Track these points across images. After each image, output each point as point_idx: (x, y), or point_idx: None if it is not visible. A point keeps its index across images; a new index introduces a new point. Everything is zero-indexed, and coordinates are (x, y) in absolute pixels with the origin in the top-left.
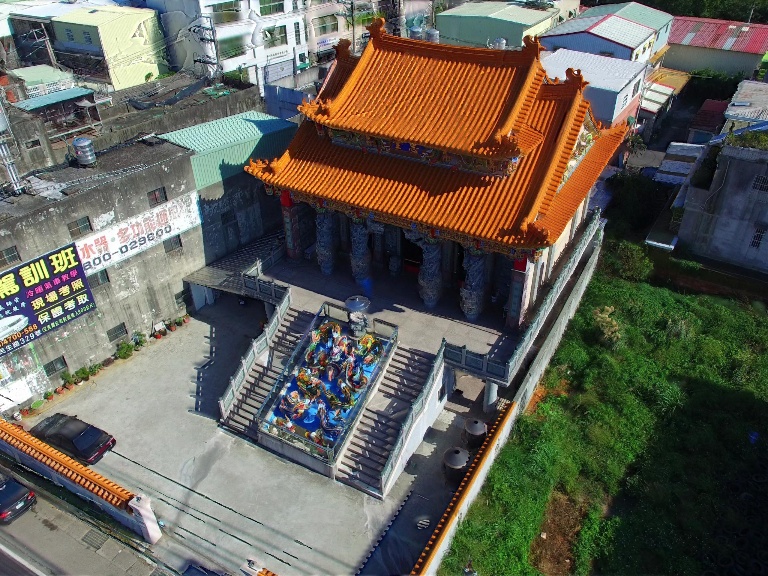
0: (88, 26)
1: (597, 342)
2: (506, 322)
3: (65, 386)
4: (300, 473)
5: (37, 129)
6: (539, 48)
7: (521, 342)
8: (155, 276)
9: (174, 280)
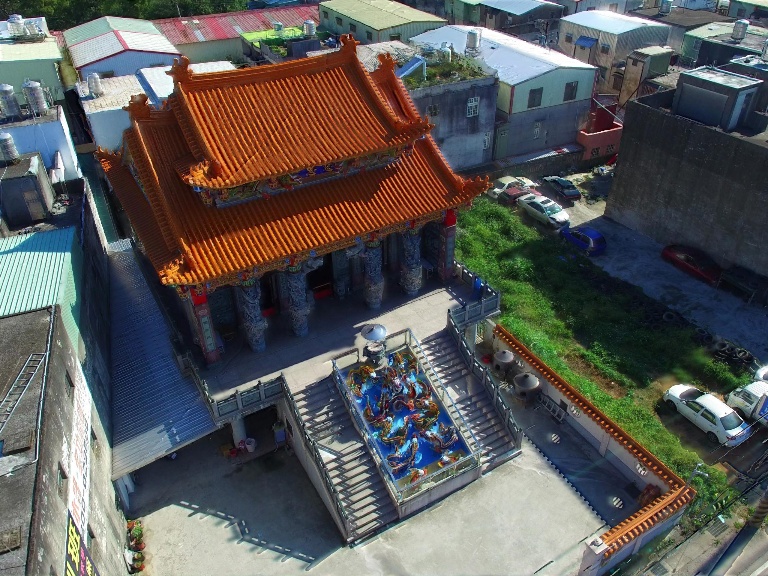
0: None
1: None
2: (444, 277)
3: None
4: (460, 499)
5: None
6: (355, 44)
7: None
8: None
9: (109, 488)
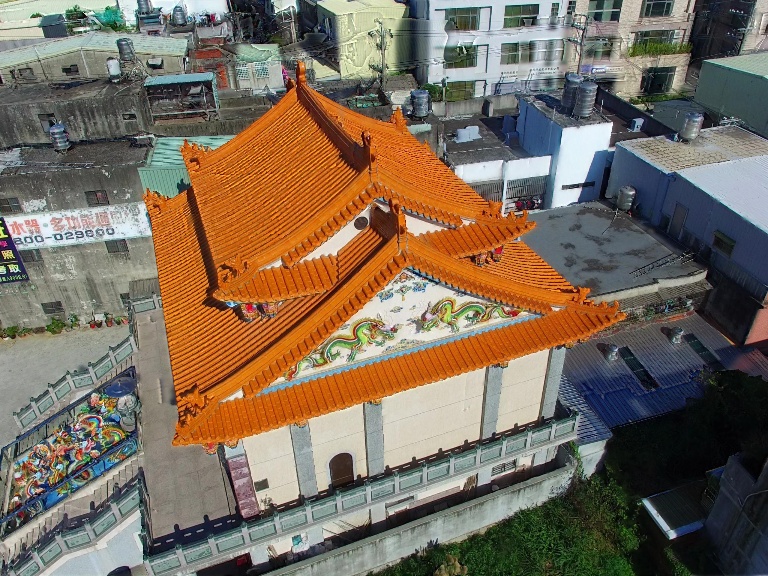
0: (332, 14)
1: None
2: None
3: None
4: None
5: (135, 104)
6: (371, 154)
7: (198, 541)
8: (96, 270)
9: (119, 280)
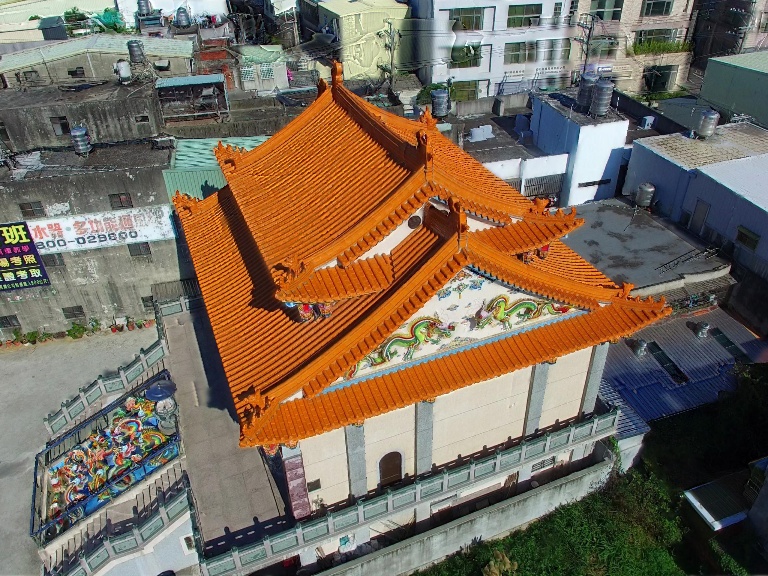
0: (335, 14)
1: None
2: None
3: (13, 341)
4: None
5: (147, 106)
6: (427, 153)
7: (254, 543)
8: (118, 274)
9: (141, 283)
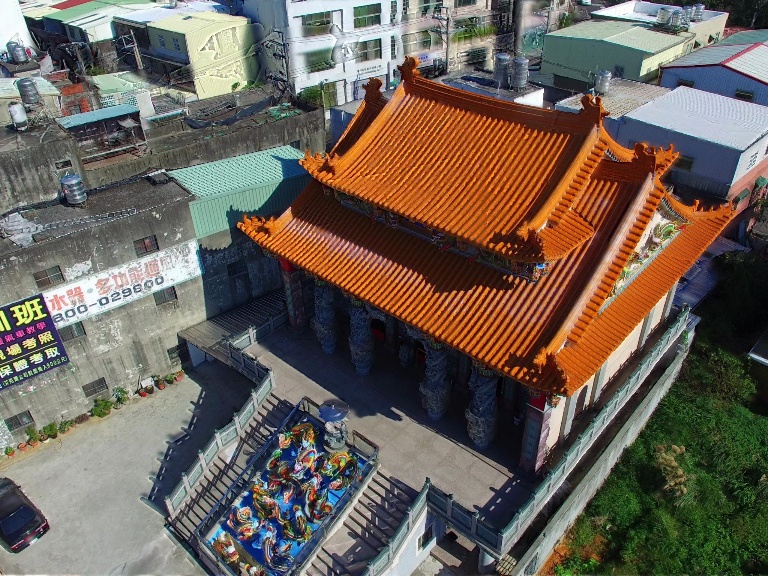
0: (177, 33)
1: (655, 489)
2: (520, 462)
3: (29, 442)
4: None
5: (68, 149)
6: (601, 113)
7: (528, 501)
8: (143, 329)
9: (167, 334)
